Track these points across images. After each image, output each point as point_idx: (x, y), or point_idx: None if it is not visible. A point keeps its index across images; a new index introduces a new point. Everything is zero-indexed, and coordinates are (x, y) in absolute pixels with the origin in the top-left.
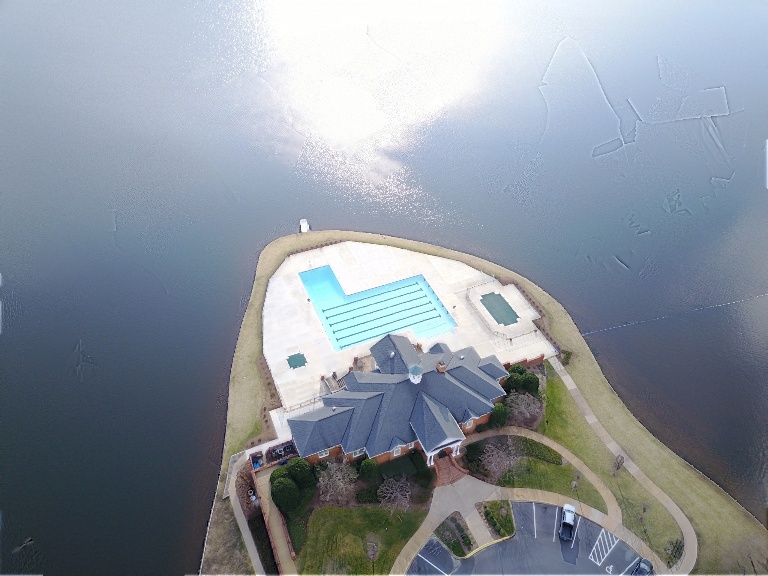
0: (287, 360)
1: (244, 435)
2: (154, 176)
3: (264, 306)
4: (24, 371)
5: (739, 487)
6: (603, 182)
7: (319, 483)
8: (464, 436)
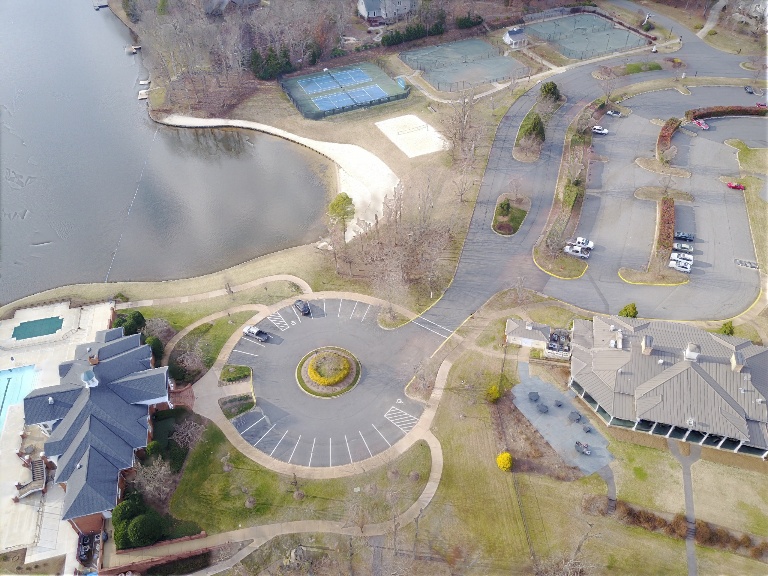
0: None
1: None
2: None
3: None
4: None
5: (267, 248)
6: None
7: (149, 495)
8: (165, 367)
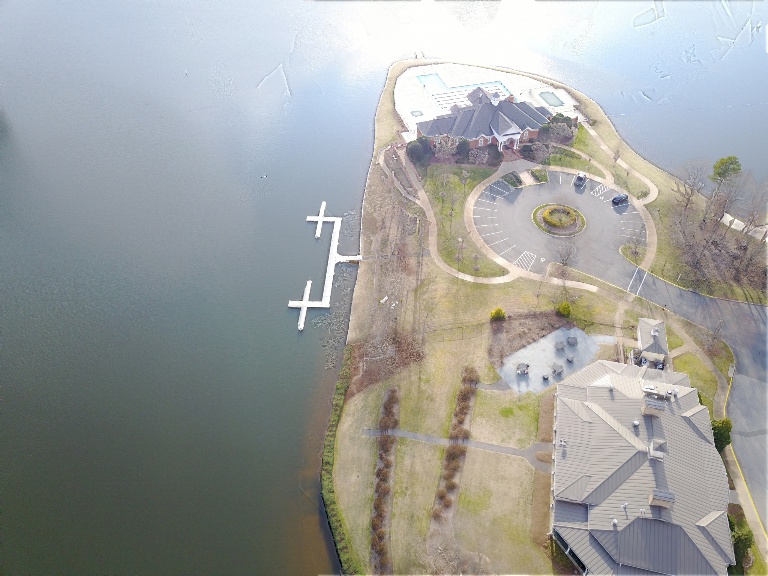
0: (411, 113)
1: (386, 141)
2: (320, 16)
3: (395, 90)
4: (258, 98)
5: None
6: (639, 43)
7: (435, 148)
8: (522, 132)
